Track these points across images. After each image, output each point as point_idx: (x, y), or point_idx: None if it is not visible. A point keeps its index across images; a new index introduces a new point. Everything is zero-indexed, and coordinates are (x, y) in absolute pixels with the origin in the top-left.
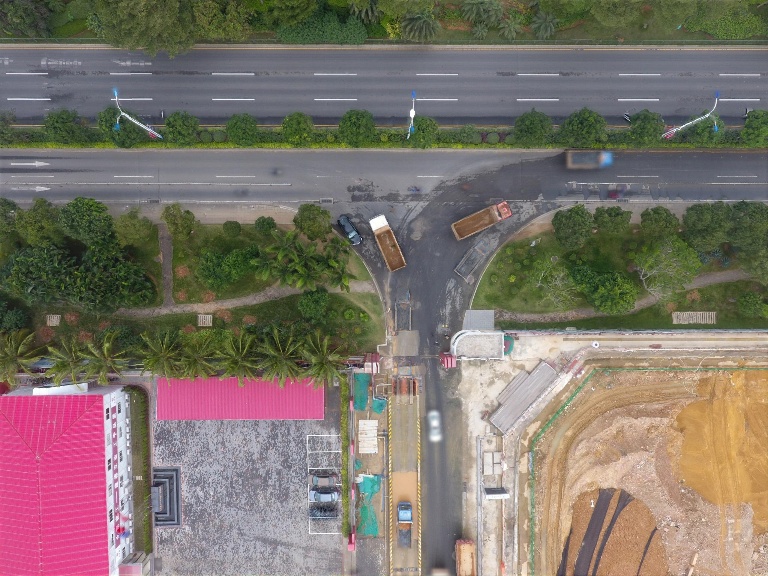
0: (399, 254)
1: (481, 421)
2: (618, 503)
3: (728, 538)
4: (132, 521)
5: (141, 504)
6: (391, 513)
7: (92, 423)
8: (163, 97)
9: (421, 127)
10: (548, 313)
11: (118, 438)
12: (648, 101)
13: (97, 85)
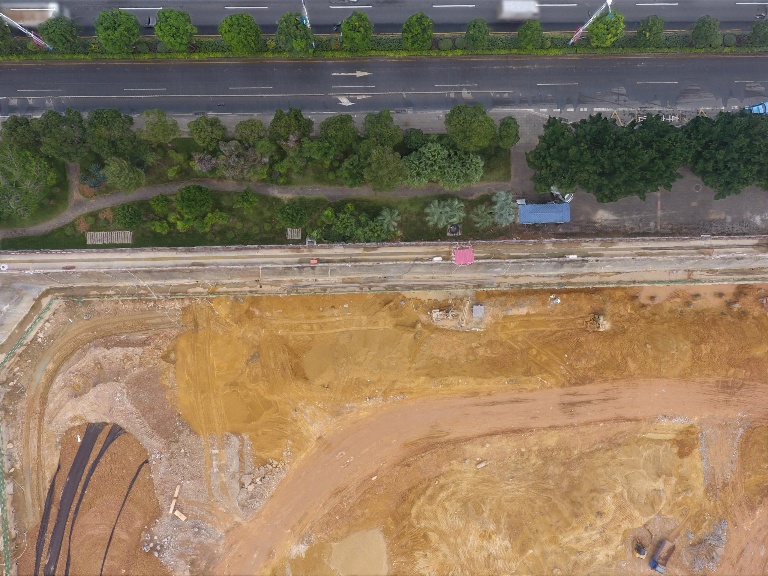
0: None
1: None
2: (107, 437)
3: (213, 469)
4: None
5: None
6: None
7: None
8: None
9: None
10: None
11: None
12: (46, 11)
13: None
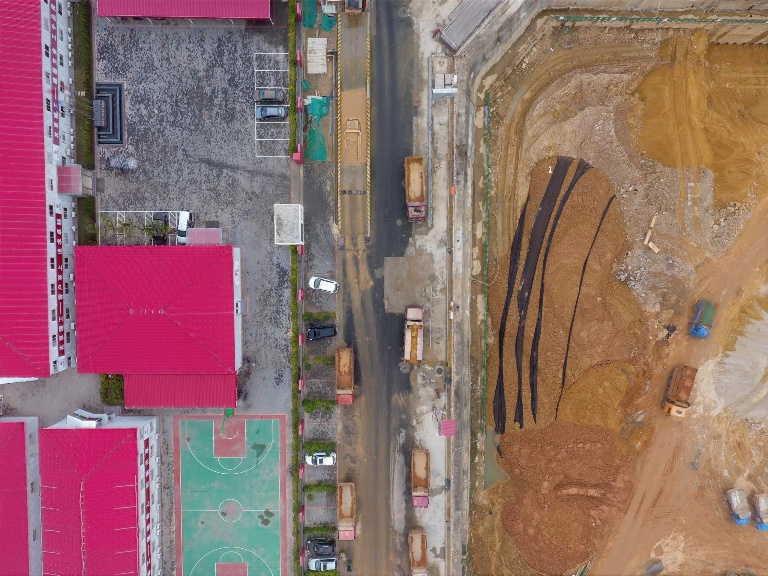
0: None
1: (433, 41)
2: (576, 170)
3: (687, 202)
4: (74, 137)
5: (83, 121)
6: (339, 132)
7: None
8: None
9: None
10: None
11: (58, 38)
12: None
13: None
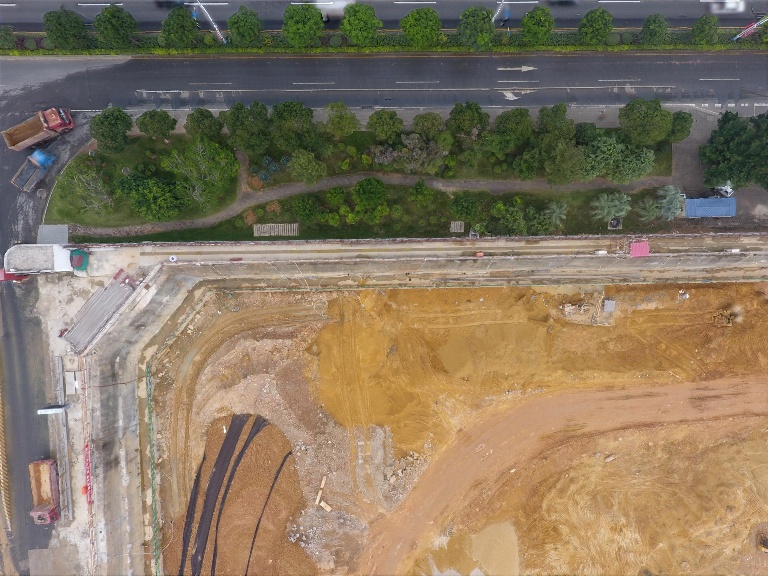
0: None
1: (62, 340)
2: (252, 428)
3: (358, 460)
4: None
5: None
6: None
7: None
8: None
9: None
10: (123, 227)
11: None
12: (218, 5)
13: None
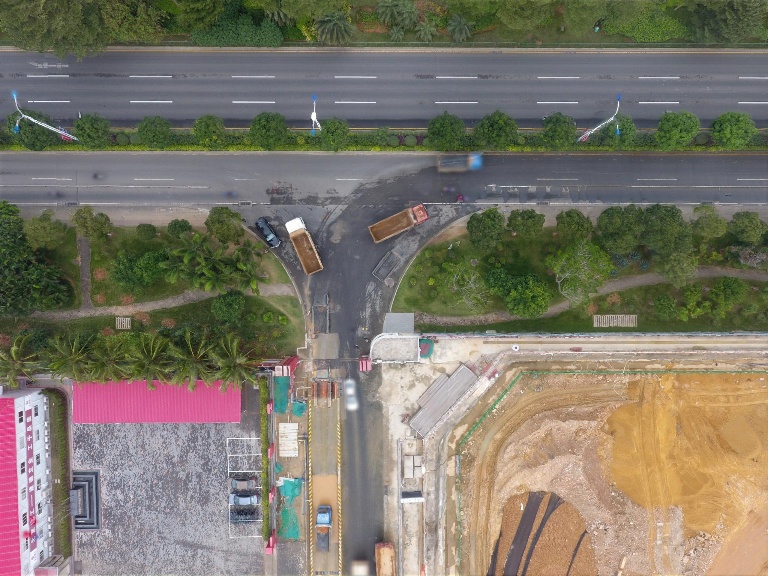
0: (316, 257)
1: (402, 424)
2: (548, 506)
3: (657, 541)
4: (51, 524)
5: (61, 507)
6: (311, 516)
7: (3, 426)
8: (80, 99)
9: (330, 130)
10: (468, 316)
11: (34, 441)
12: (567, 104)
13: (14, 87)
